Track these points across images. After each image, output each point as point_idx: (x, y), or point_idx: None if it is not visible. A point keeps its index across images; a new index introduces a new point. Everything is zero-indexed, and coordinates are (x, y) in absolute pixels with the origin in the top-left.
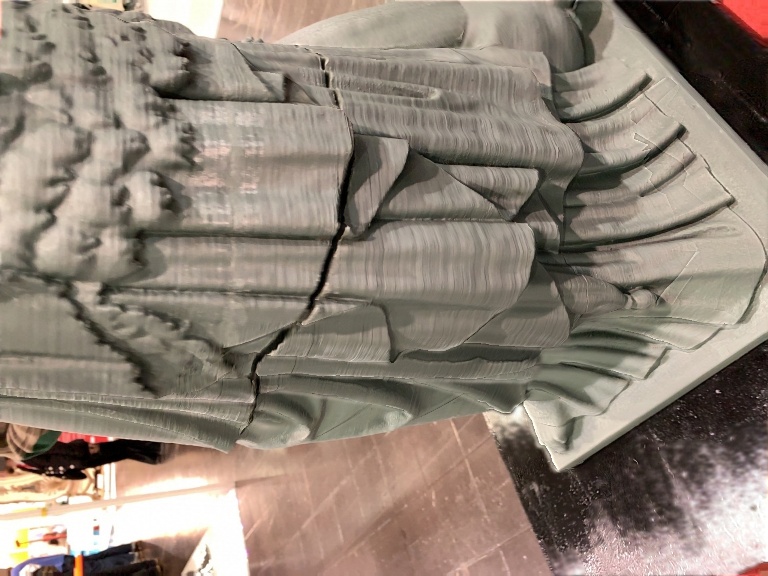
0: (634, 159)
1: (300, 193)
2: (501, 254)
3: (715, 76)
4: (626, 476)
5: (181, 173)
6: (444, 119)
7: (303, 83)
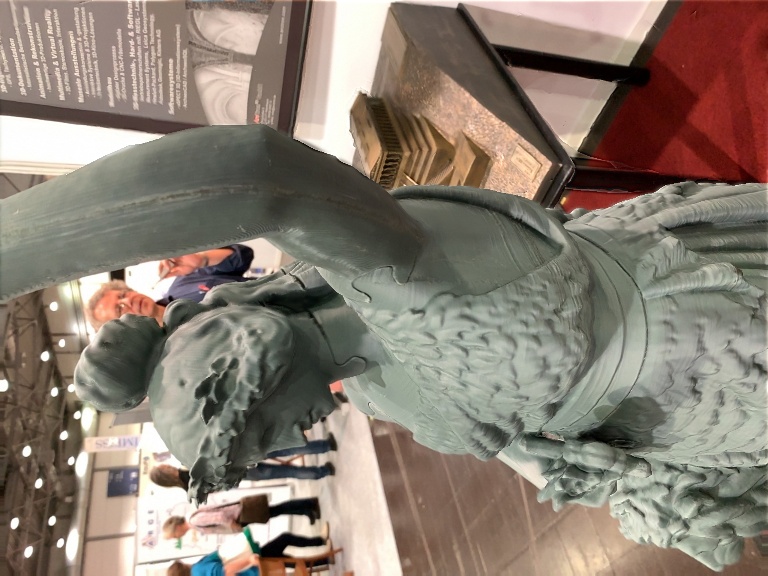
0: None
1: None
2: None
3: None
4: None
5: None
6: None
7: None
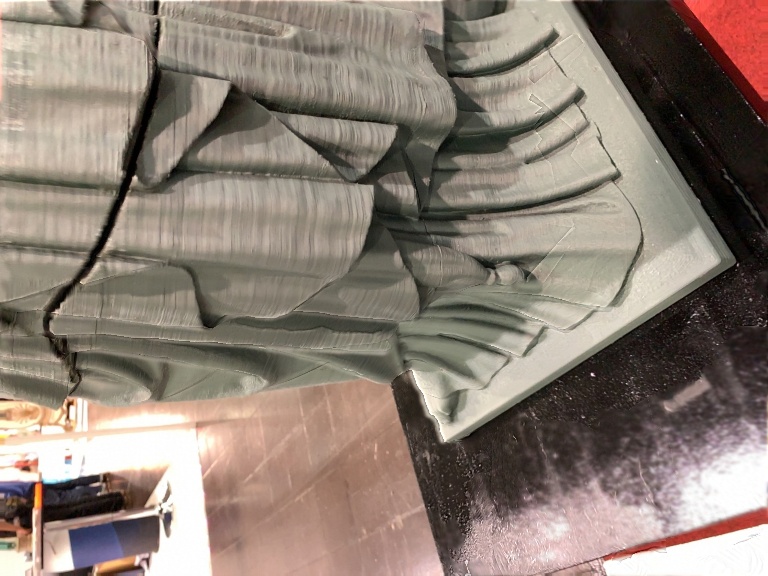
0: (525, 122)
1: (79, 134)
2: (330, 218)
3: (622, 36)
4: (505, 452)
5: None
6: (291, 61)
7: (120, 7)
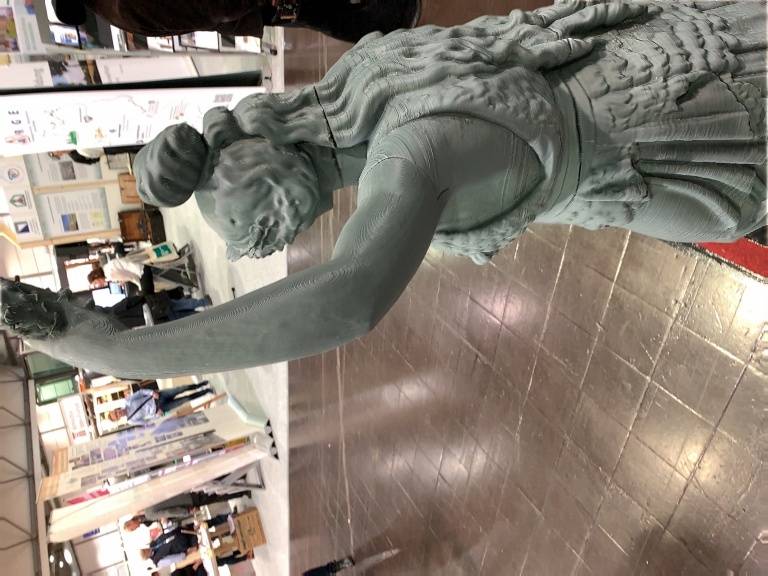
0: None
1: None
2: None
3: None
4: None
5: (726, 31)
6: None
7: None
